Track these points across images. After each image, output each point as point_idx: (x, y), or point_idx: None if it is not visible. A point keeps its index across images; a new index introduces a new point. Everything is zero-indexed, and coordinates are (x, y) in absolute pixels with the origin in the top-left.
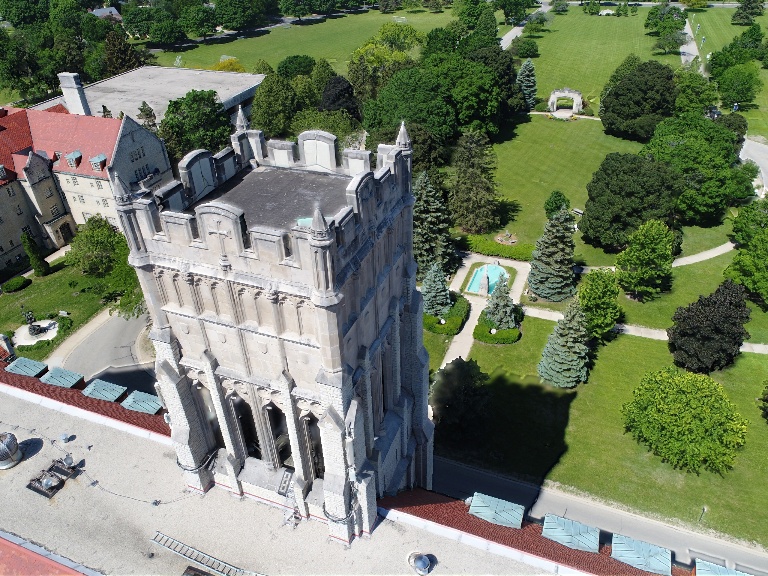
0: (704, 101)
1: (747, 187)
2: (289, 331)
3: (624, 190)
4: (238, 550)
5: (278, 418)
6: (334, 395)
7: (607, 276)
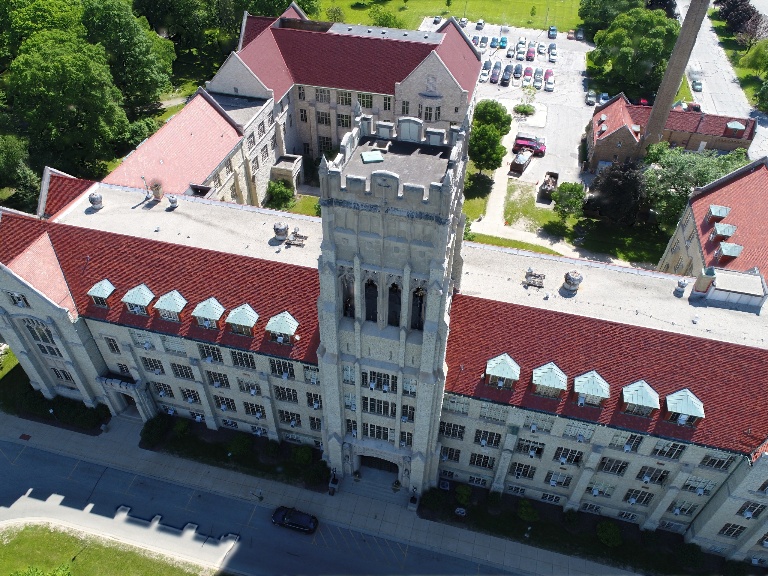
0: None
1: None
2: None
3: None
4: None
5: None
6: None
7: None
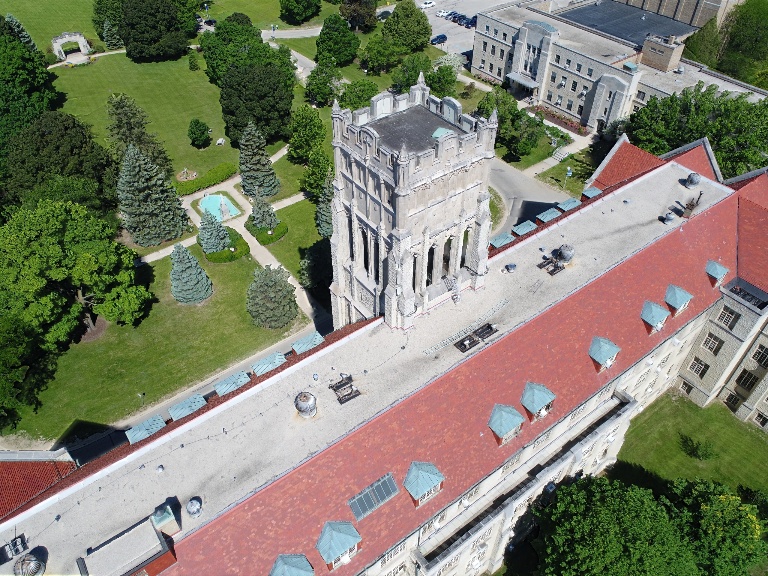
0: (191, 9)
1: (289, 64)
2: (467, 185)
3: (256, 95)
4: (458, 325)
5: (447, 246)
6: (486, 204)
7: (321, 151)
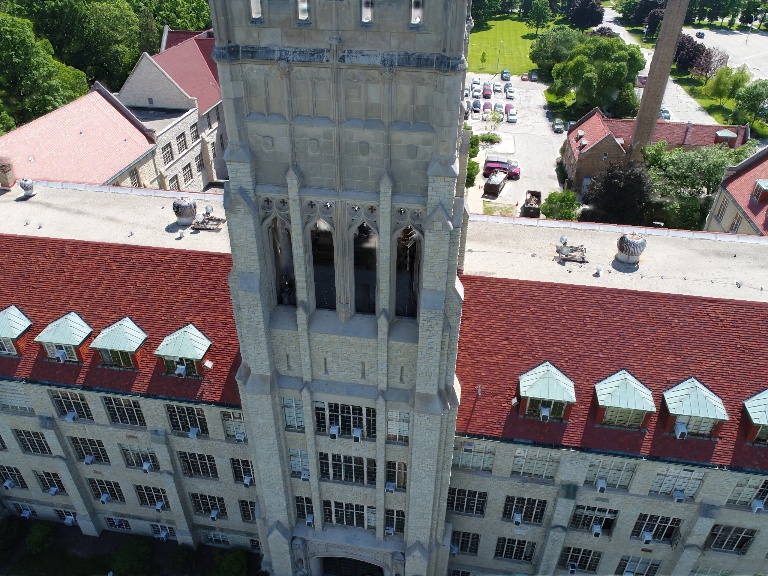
0: None
1: None
2: None
3: None
4: None
5: None
6: None
7: None
